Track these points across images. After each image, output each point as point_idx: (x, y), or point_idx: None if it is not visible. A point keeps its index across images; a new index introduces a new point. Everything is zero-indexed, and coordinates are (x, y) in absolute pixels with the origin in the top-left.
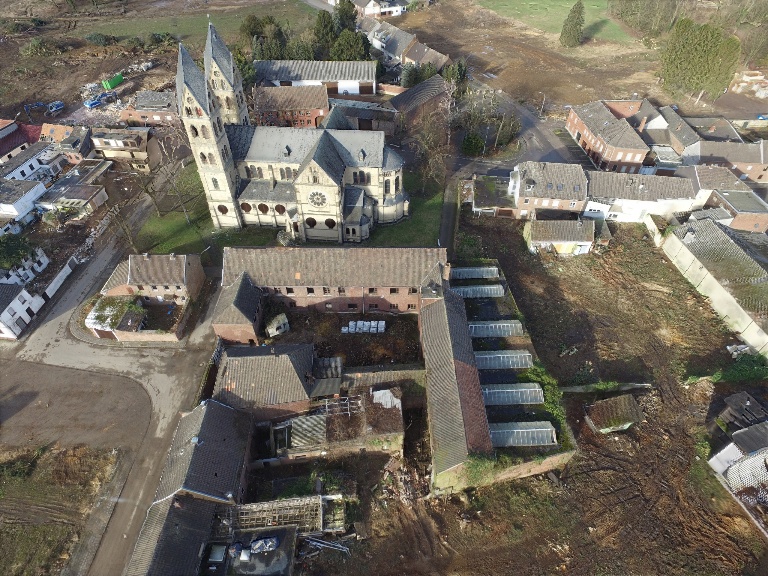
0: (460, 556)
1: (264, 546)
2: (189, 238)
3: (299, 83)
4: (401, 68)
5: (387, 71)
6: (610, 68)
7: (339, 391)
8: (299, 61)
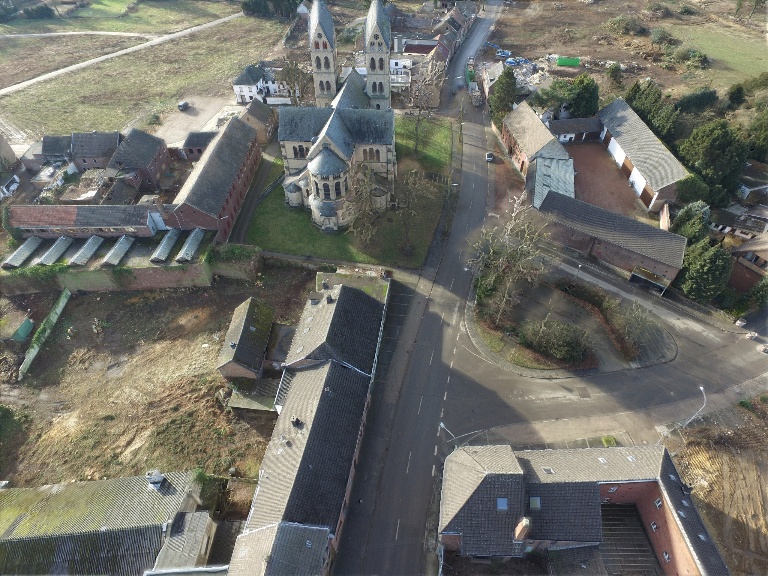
0: (1, 243)
1: (49, 172)
2: None
3: (615, 142)
4: (763, 227)
5: (730, 211)
6: None
7: (104, 176)
8: (641, 121)
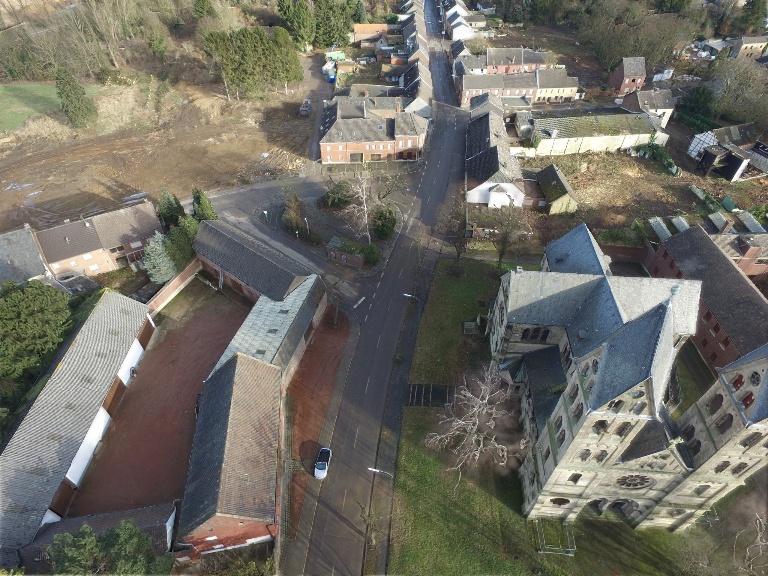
0: None
1: None
2: (733, 574)
3: (74, 457)
4: (71, 281)
5: None
6: (170, 115)
7: None
8: (15, 437)
